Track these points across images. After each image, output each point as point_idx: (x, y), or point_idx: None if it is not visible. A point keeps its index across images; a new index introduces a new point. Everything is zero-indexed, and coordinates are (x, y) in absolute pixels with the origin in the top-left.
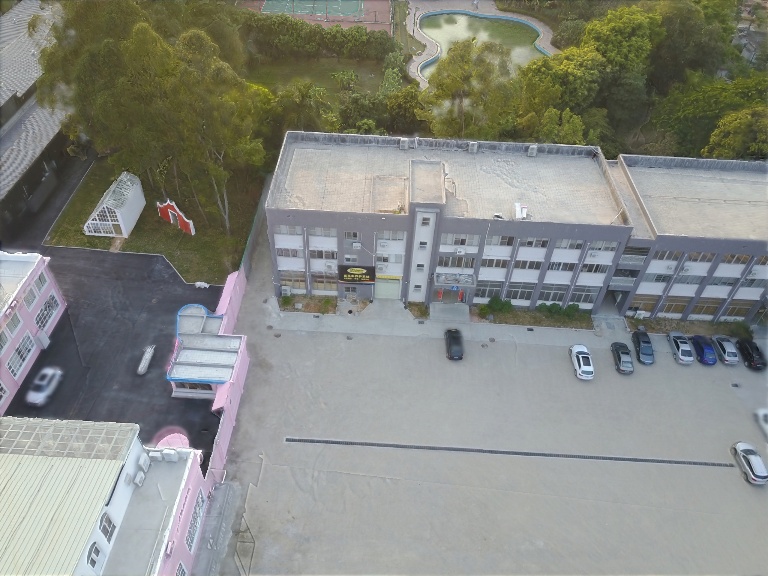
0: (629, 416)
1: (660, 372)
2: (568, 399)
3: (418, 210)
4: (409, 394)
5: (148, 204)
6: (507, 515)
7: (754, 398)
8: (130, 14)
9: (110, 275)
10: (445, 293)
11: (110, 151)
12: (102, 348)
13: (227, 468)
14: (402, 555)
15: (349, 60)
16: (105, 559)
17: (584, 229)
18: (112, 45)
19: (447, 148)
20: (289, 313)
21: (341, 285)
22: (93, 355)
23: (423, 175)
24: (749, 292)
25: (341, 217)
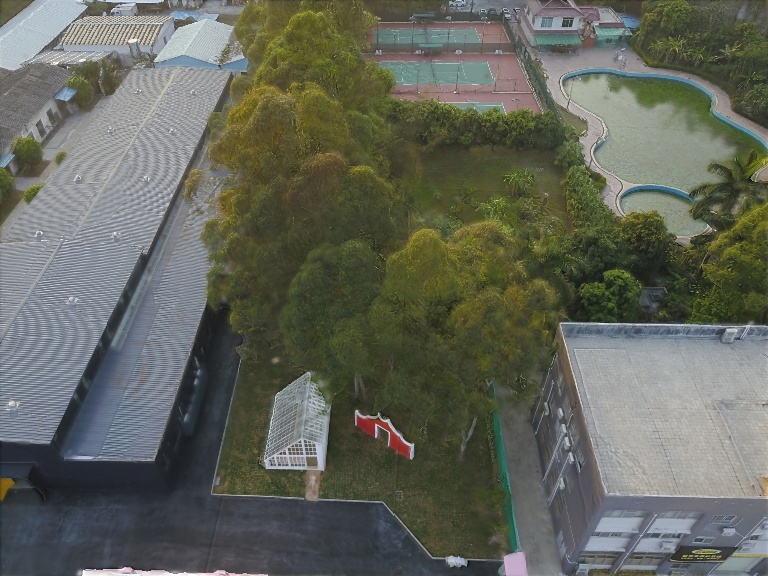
0: None
1: None
2: None
3: None
4: None
5: (334, 404)
6: None
7: None
8: (375, 195)
9: (320, 548)
10: None
11: None
12: None
13: None
14: None
15: (507, 149)
16: None
17: None
18: (360, 252)
19: None
20: None
21: (670, 562)
22: None
23: None
24: None
25: (721, 502)
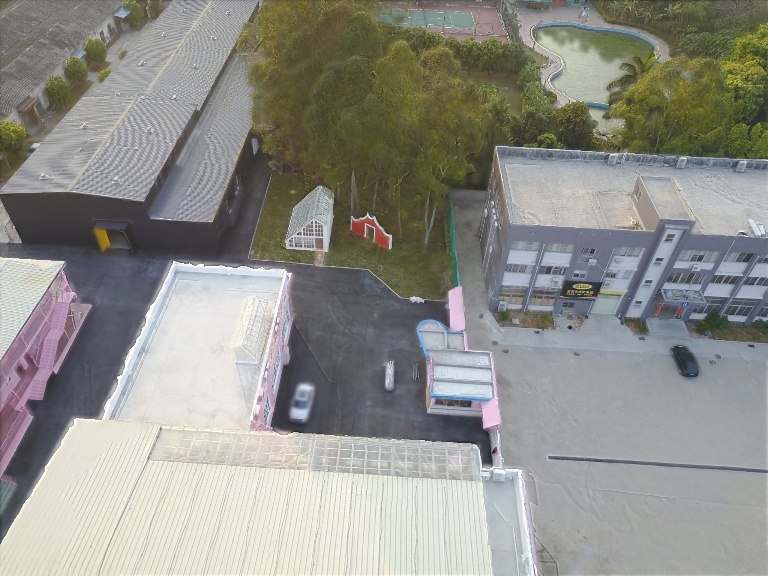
0: None
1: None
2: None
3: (668, 227)
4: (654, 411)
5: (336, 218)
6: None
7: None
8: (371, 31)
9: (324, 289)
10: (663, 309)
11: (331, 166)
12: (342, 363)
13: None
14: None
15: (480, 73)
16: None
17: None
18: (360, 62)
19: (654, 163)
20: (509, 328)
21: (560, 300)
22: (335, 371)
23: (658, 191)
24: None
25: (585, 233)
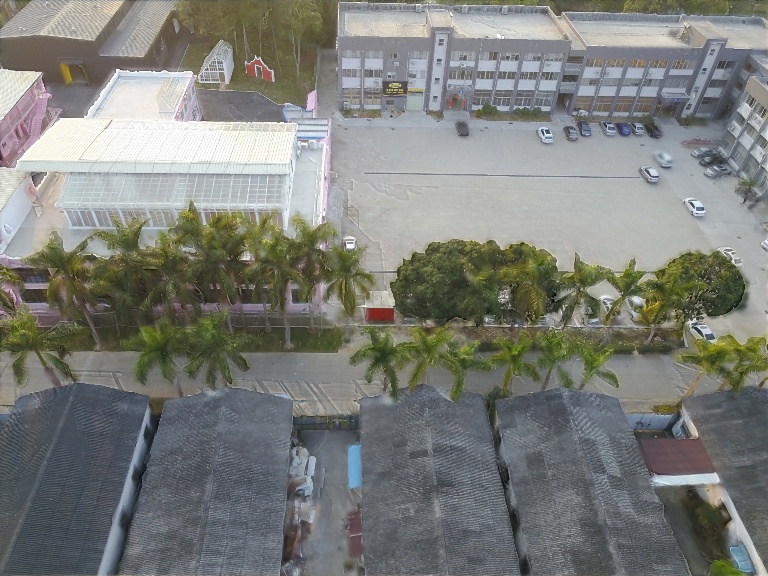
0: (576, 159)
1: (595, 140)
2: (538, 153)
3: (437, 32)
4: (437, 153)
5: (236, 67)
6: (505, 198)
7: (654, 150)
8: None
9: (225, 102)
10: (453, 102)
11: (223, 14)
12: None
13: (332, 184)
14: (446, 214)
15: None
16: (292, 180)
17: (541, 44)
18: None
19: None
20: (350, 118)
21: (384, 99)
22: None
23: (436, 17)
24: (649, 91)
25: (387, 41)
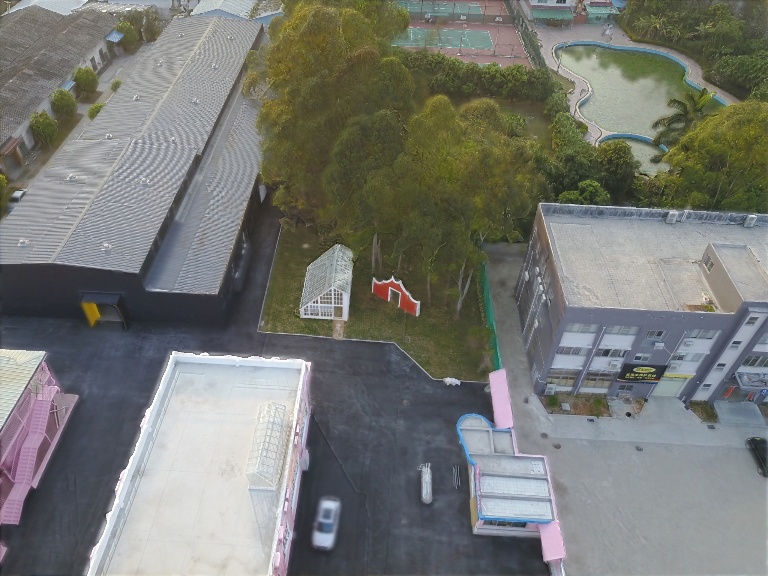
0: None
1: None
2: None
3: (752, 310)
4: (735, 524)
5: (355, 277)
6: None
7: None
8: (402, 80)
9: (345, 369)
10: (734, 391)
11: (354, 231)
12: (370, 467)
13: None
14: None
15: (503, 100)
16: None
17: None
18: (390, 118)
19: (718, 221)
20: (559, 416)
21: (617, 383)
22: (363, 477)
23: (734, 263)
24: None
25: (653, 316)
